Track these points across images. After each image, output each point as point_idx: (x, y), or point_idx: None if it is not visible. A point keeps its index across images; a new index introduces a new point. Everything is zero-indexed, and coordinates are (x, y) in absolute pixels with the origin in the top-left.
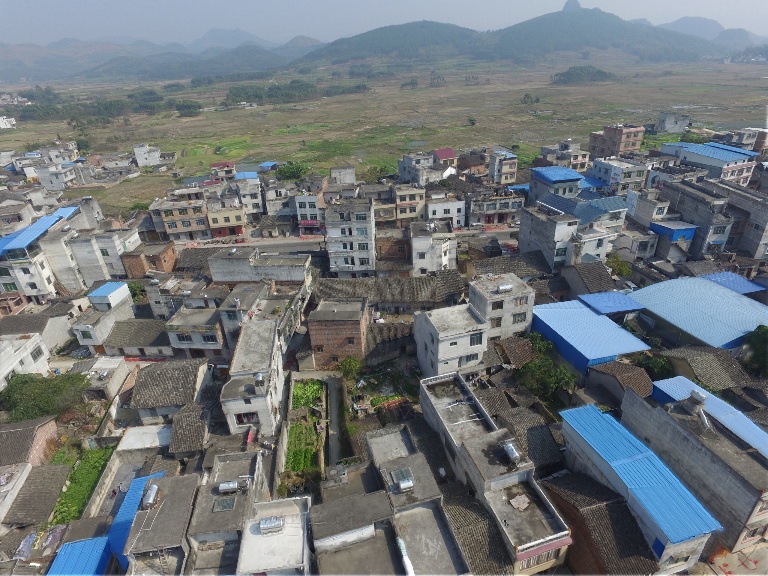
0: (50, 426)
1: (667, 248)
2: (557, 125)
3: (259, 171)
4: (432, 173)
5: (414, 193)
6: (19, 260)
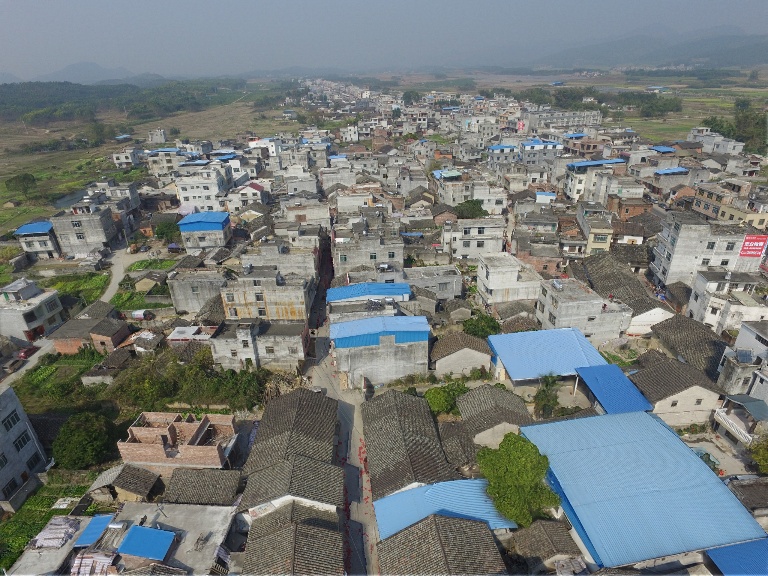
0: (454, 216)
1: None
2: None
3: None
4: None
5: None
6: (573, 173)
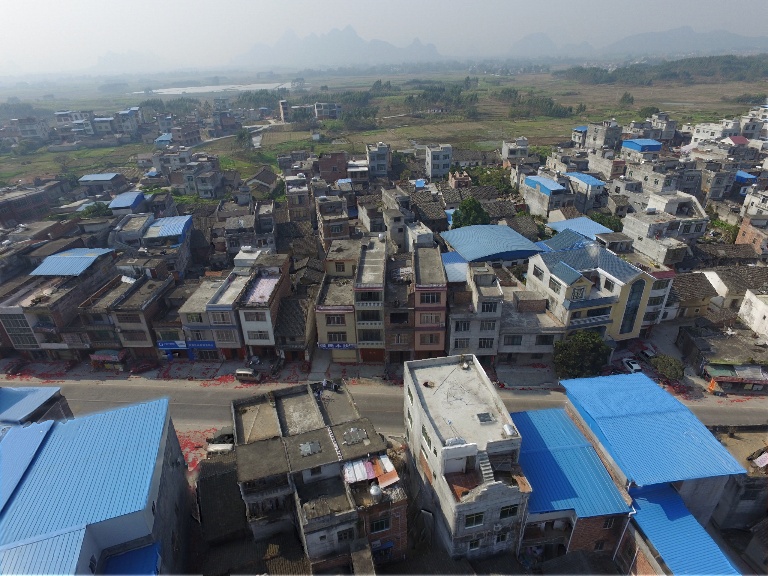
0: None
1: None
2: None
3: None
4: None
5: None
6: None
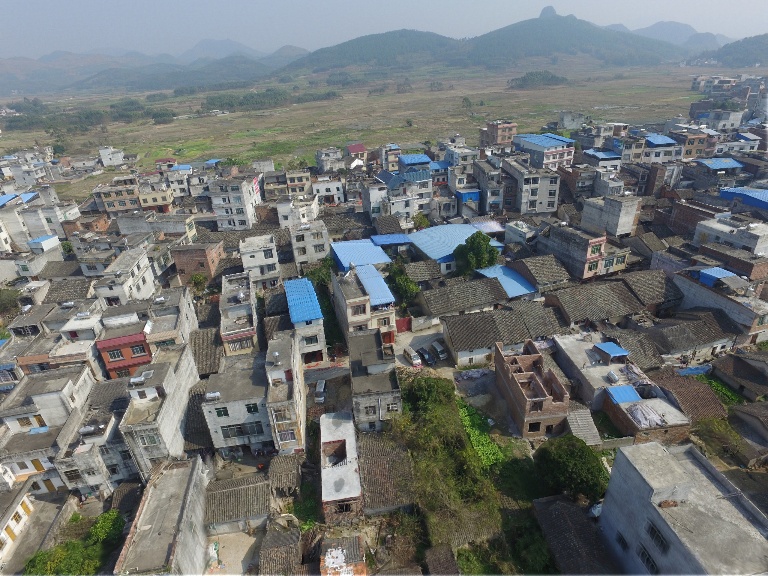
0: None
1: (461, 208)
2: (483, 125)
3: (205, 167)
4: (335, 163)
5: (301, 176)
6: None
